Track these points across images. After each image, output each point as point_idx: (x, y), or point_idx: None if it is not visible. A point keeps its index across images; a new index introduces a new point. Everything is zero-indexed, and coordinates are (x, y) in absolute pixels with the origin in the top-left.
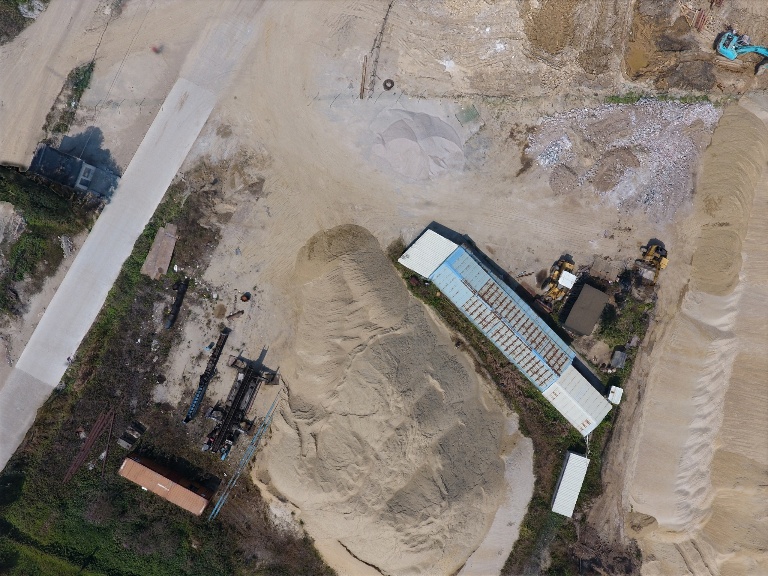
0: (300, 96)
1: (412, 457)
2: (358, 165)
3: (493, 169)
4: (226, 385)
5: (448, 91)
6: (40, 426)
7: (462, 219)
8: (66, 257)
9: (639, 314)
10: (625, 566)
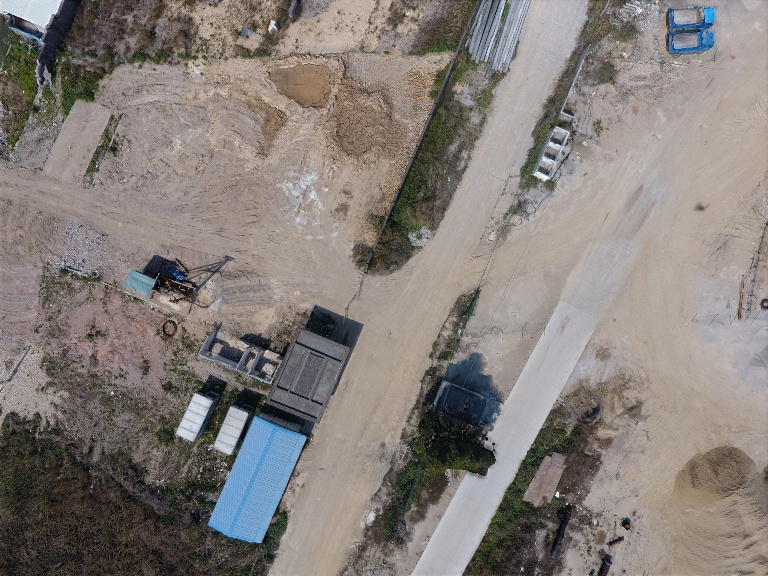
0: (678, 317)
1: None
2: (735, 386)
3: None
4: None
5: None
6: None
7: None
8: (450, 485)
9: None
10: None
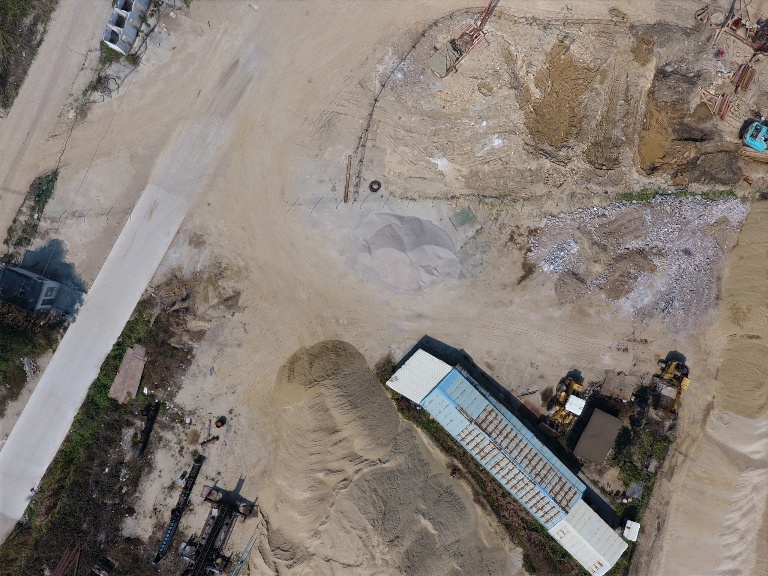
0: (279, 201)
1: None
2: (342, 275)
3: (491, 276)
4: (200, 518)
5: (441, 192)
6: (2, 564)
7: (457, 332)
8: (29, 380)
9: (657, 436)
10: None
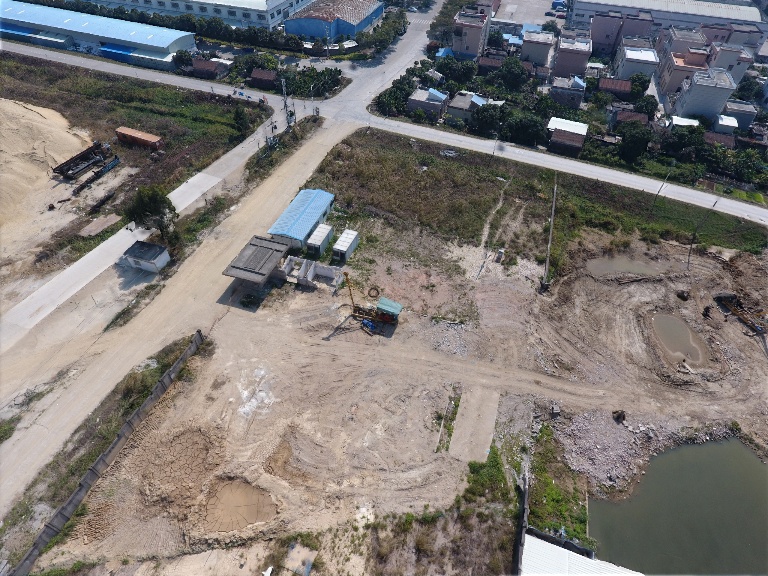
0: None
1: None
2: None
3: None
4: (89, 174)
5: None
6: None
7: None
8: None
9: None
10: None
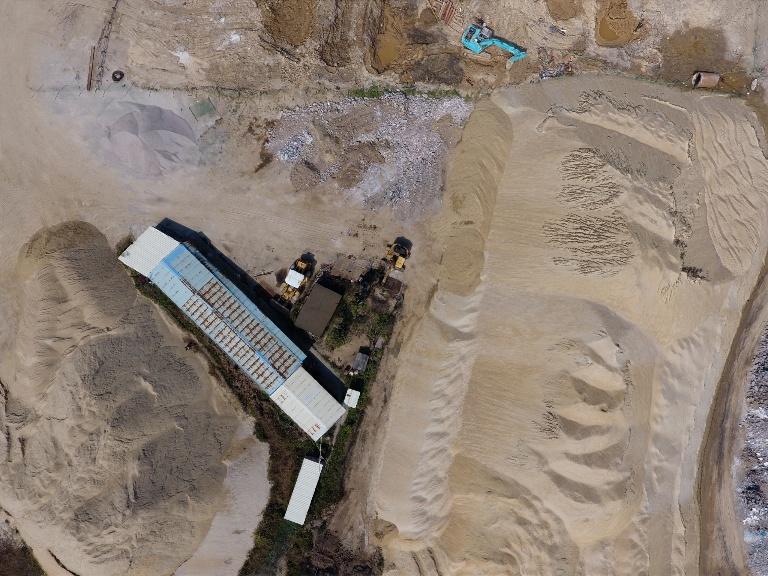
0: (23, 87)
1: (104, 463)
2: (85, 159)
3: (230, 164)
4: None
5: (182, 83)
6: None
7: (197, 216)
8: None
9: (384, 315)
10: (363, 575)
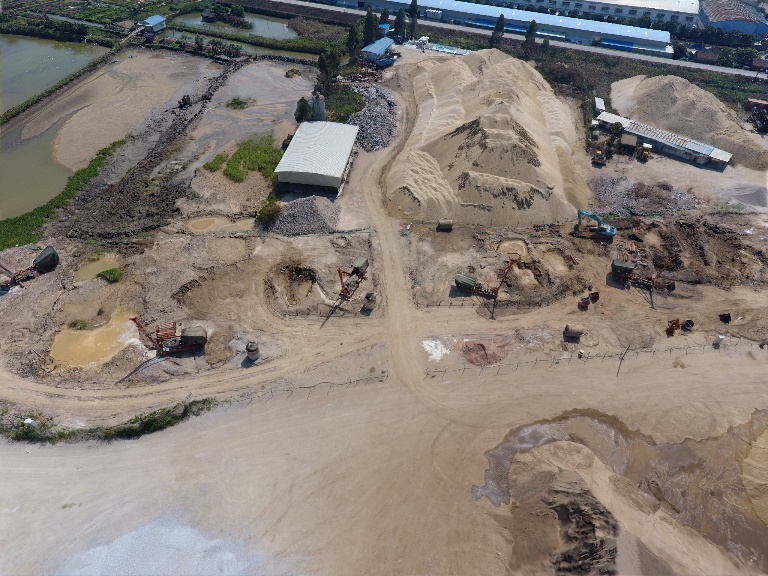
0: None
1: None
2: None
3: None
4: None
5: (760, 216)
6: None
7: None
8: None
9: None
10: (562, 89)
